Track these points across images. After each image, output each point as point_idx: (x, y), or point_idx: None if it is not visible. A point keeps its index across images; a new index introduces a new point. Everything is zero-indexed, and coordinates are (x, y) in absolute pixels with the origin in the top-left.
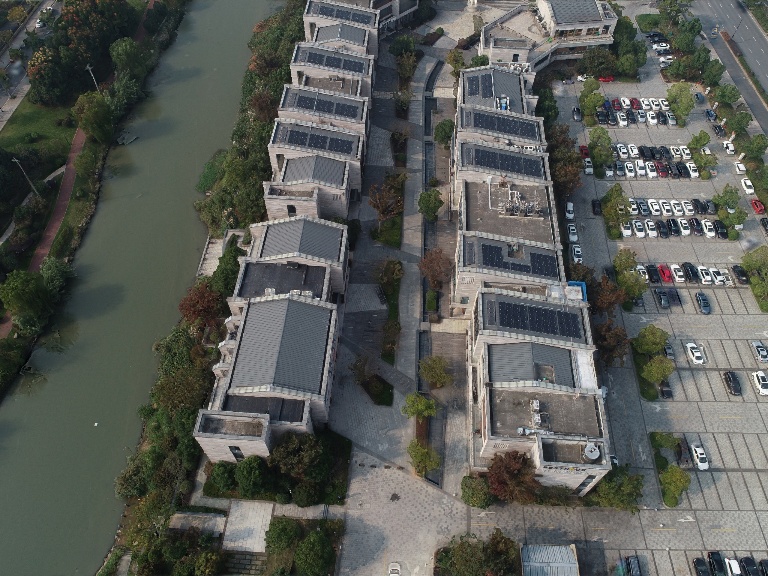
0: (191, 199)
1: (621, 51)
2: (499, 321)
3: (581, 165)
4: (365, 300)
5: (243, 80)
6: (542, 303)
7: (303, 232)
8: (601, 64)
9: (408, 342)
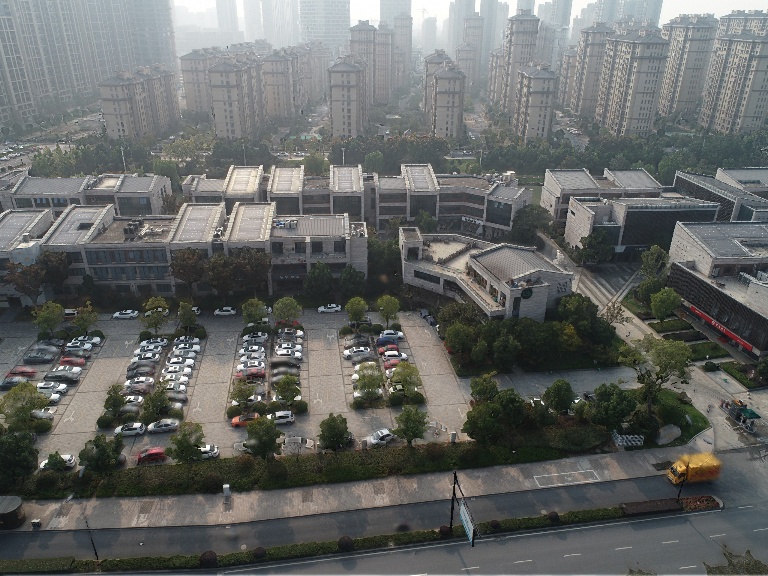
0: None
1: None
2: (15, 216)
3: None
4: None
5: None
6: None
7: None
8: None
9: None
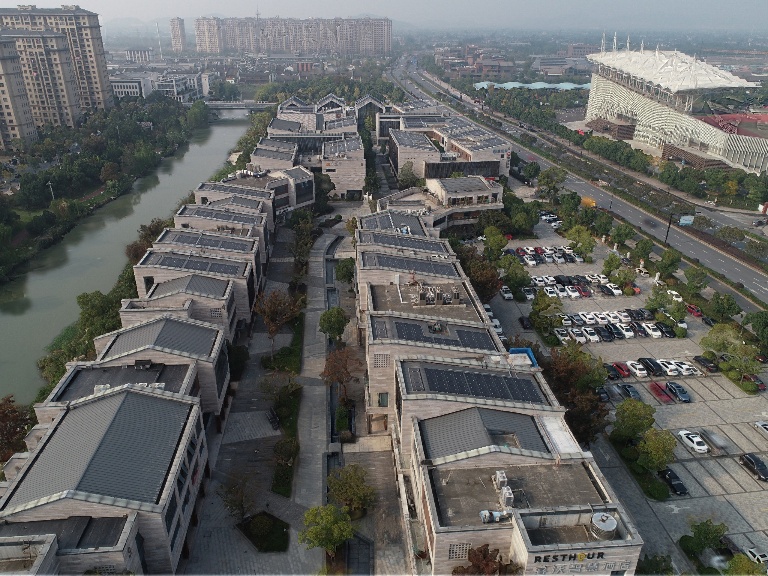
0: (36, 360)
1: (513, 212)
2: (428, 386)
3: (497, 275)
4: (251, 428)
5: (128, 261)
6: (482, 370)
7: (163, 329)
8: (497, 222)
9: (311, 468)
